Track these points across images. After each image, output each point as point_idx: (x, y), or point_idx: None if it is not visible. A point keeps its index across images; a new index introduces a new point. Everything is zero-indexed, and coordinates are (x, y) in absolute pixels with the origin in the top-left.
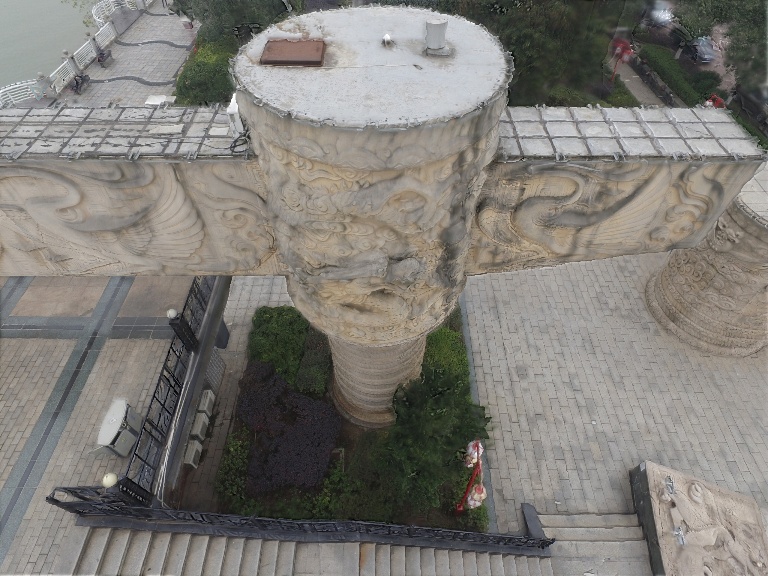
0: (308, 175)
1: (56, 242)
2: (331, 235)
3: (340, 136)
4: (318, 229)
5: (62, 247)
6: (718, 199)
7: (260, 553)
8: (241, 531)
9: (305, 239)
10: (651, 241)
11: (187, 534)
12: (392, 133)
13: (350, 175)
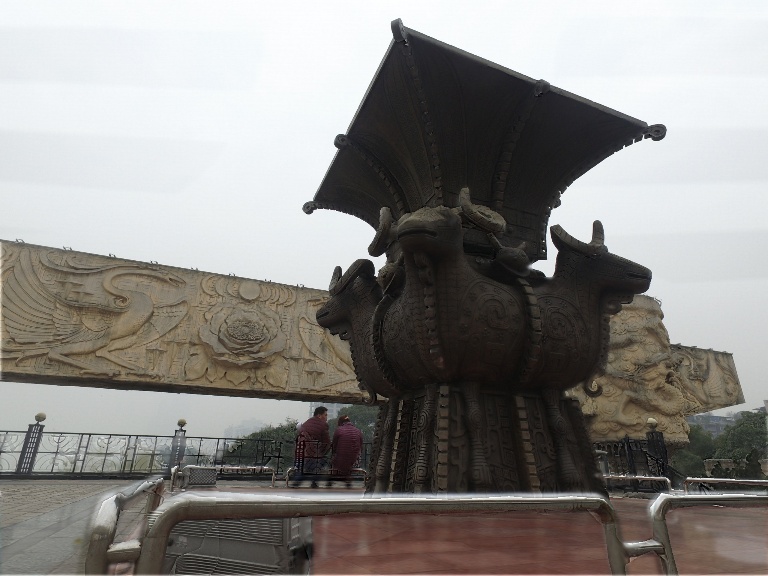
0: (625, 317)
1: None
2: (639, 346)
3: (637, 298)
4: (635, 341)
5: None
6: (733, 372)
7: None
8: None
9: (625, 354)
10: (729, 397)
11: None
12: (649, 299)
13: (642, 313)
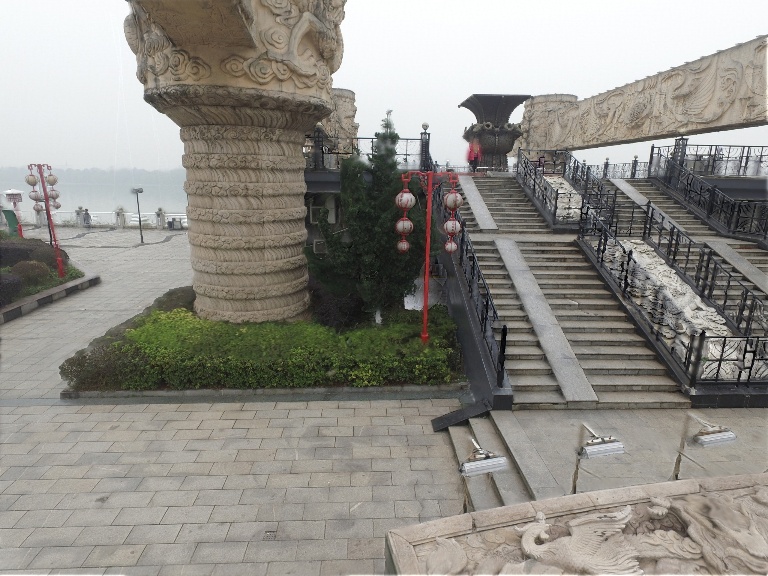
0: None
1: (760, 91)
2: None
3: None
4: None
5: (760, 96)
6: None
7: (694, 221)
8: (697, 212)
9: None
10: None
11: (673, 200)
12: None
13: None
